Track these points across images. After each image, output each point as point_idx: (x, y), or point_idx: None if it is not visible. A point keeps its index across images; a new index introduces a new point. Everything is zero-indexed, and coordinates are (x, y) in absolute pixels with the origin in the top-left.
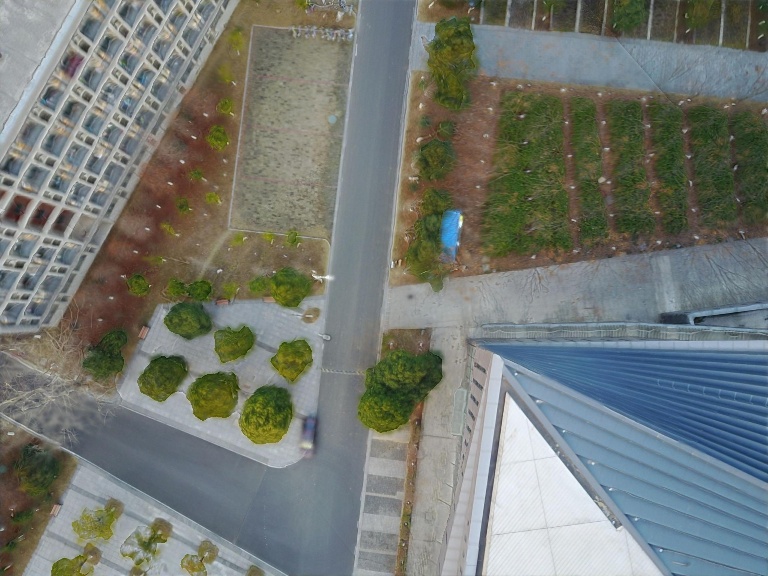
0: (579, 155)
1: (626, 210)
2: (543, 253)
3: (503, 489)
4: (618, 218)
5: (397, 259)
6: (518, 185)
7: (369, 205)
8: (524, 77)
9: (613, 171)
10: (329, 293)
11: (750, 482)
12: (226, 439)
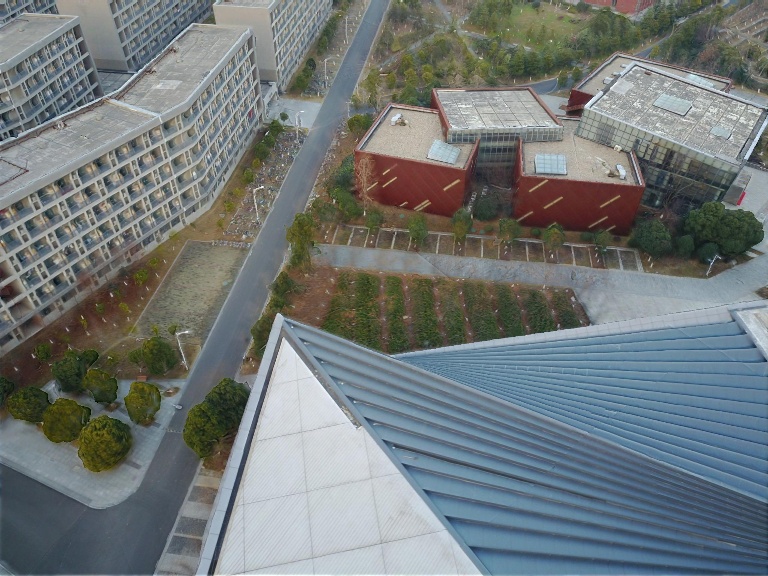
0: None
1: (421, 331)
2: None
3: (271, 403)
4: (416, 337)
5: (250, 357)
6: None
7: (237, 327)
8: (356, 267)
9: (413, 312)
10: (191, 378)
11: (456, 386)
12: (60, 482)
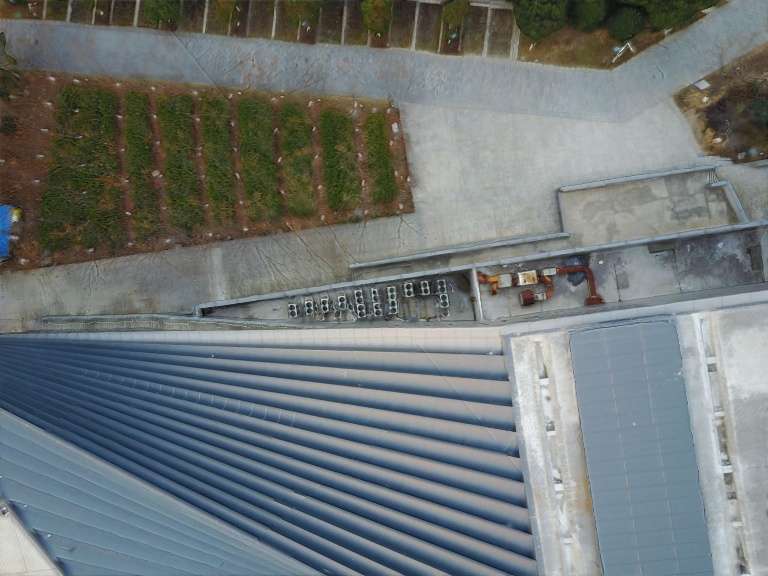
0: (129, 149)
1: (174, 203)
2: (101, 246)
3: None
4: (169, 211)
5: None
6: (71, 179)
7: None
8: (83, 72)
9: (164, 164)
10: None
11: (109, 469)
12: None
